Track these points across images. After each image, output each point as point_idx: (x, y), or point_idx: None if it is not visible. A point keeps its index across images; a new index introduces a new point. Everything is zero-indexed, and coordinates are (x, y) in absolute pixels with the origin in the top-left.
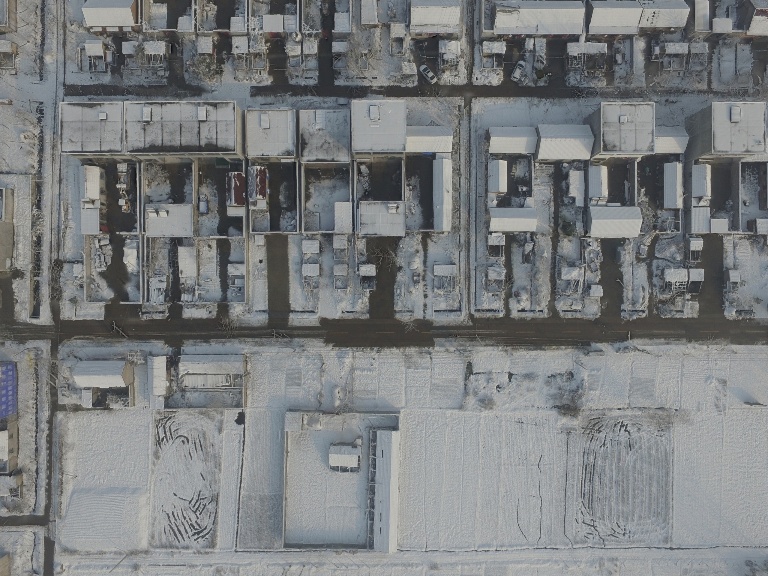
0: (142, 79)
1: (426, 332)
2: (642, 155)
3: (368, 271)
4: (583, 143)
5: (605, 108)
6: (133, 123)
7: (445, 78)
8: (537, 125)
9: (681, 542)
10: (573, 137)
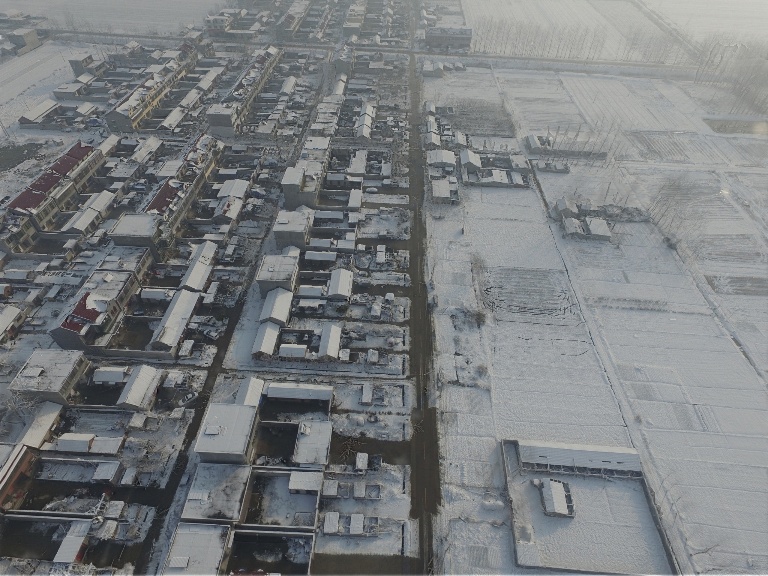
0: None
1: (423, 414)
2: (297, 265)
3: (363, 461)
4: (281, 294)
5: (260, 278)
6: None
7: (197, 387)
8: None
9: (561, 266)
10: (275, 299)
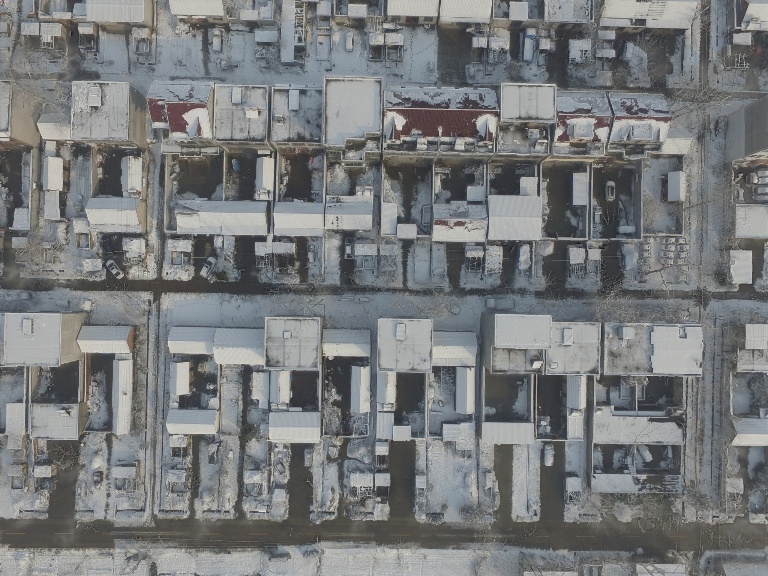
0: None
1: (106, 533)
2: None
3: (43, 473)
4: (256, 352)
5: (269, 323)
6: None
7: (134, 273)
8: None
9: None
10: (245, 346)
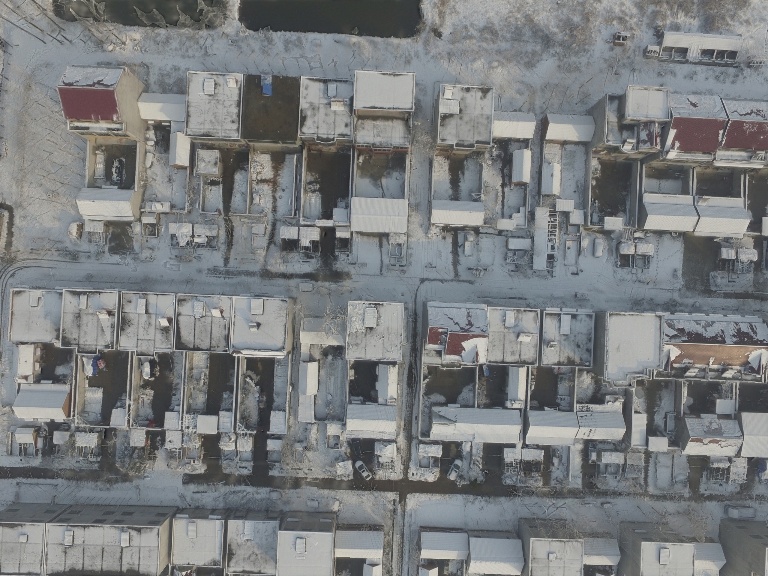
0: (73, 464)
1: None
2: None
3: None
4: (513, 565)
5: (534, 544)
6: (54, 545)
7: (381, 473)
8: (469, 536)
9: None
10: (503, 560)
